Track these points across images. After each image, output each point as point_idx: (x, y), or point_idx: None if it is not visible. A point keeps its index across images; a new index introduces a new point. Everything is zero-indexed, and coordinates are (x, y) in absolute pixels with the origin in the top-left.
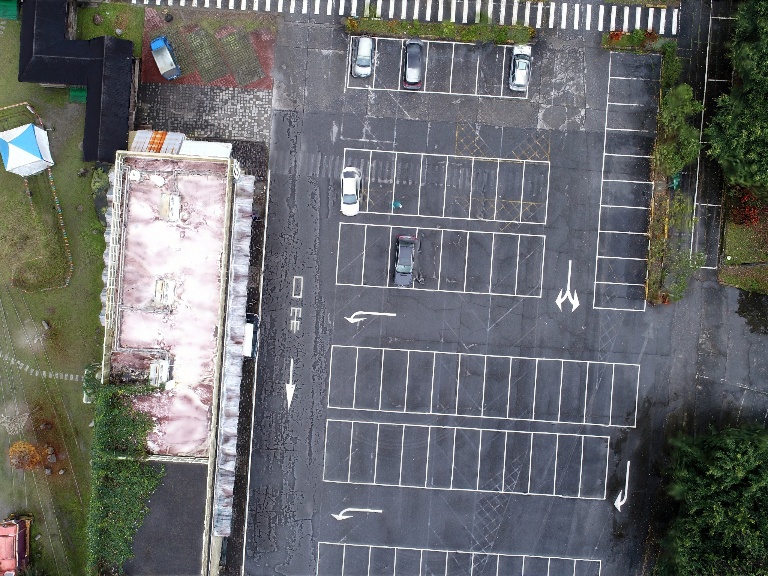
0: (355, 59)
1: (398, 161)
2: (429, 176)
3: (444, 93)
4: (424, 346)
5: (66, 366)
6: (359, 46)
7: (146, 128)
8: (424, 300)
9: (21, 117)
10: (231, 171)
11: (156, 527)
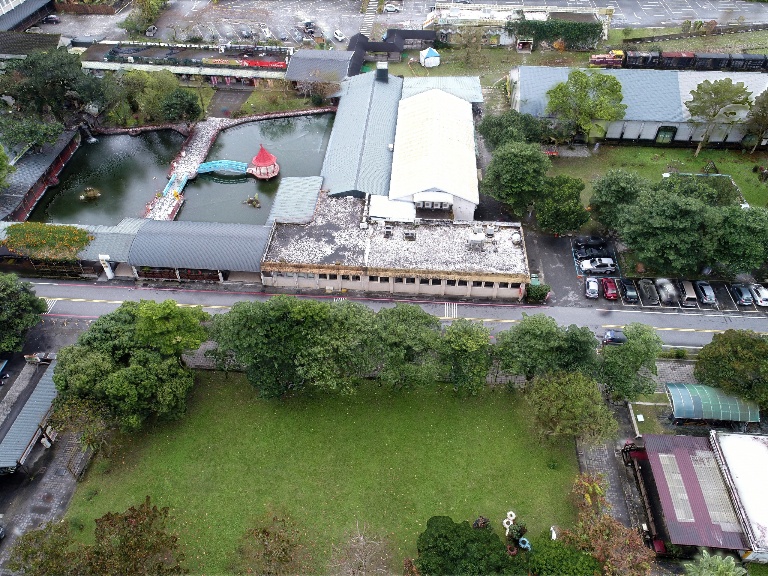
0: (393, 8)
1: (429, 6)
2: (434, 2)
3: (404, 0)
4: (494, 3)
5: (520, 58)
6: (389, 6)
7: (418, 42)
8: (478, 3)
9: (414, 66)
10: (440, 4)
11: (575, 19)
